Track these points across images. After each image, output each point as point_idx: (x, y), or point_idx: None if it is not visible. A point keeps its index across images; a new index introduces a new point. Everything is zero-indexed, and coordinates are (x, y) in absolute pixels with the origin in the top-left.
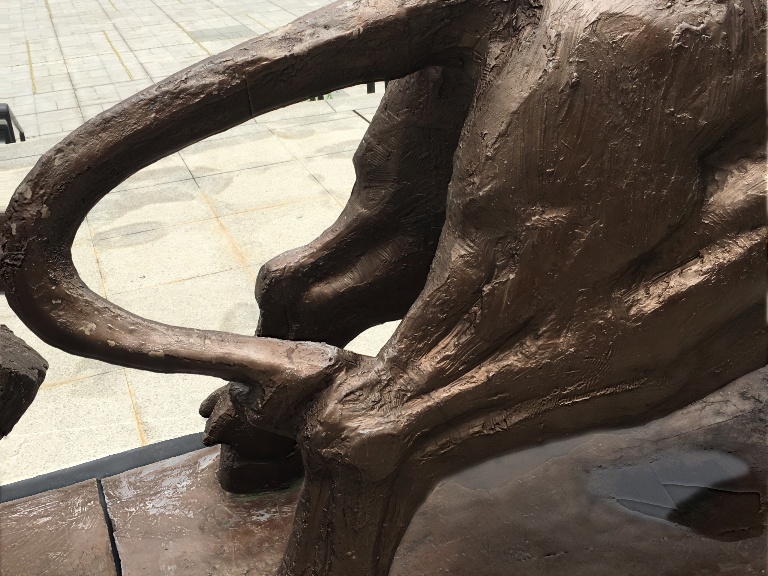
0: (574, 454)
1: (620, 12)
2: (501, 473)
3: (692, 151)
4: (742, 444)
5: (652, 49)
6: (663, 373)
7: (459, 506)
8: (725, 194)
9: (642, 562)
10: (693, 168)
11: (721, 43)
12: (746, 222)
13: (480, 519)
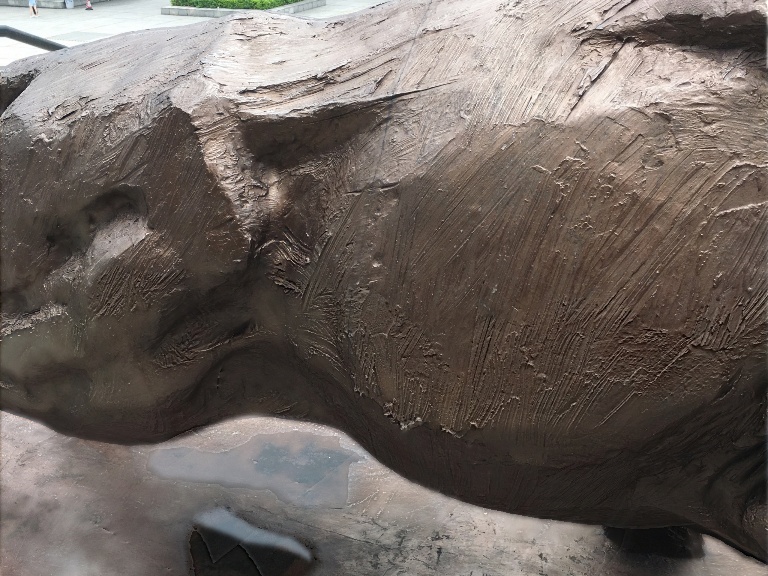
0: (231, 491)
1: (18, 116)
2: (177, 473)
3: (39, 230)
4: (333, 560)
5: (20, 147)
6: (25, 388)
7: (122, 473)
8: (58, 271)
9: (132, 569)
10: (41, 243)
11: (56, 156)
12: (59, 297)
13: (117, 487)
